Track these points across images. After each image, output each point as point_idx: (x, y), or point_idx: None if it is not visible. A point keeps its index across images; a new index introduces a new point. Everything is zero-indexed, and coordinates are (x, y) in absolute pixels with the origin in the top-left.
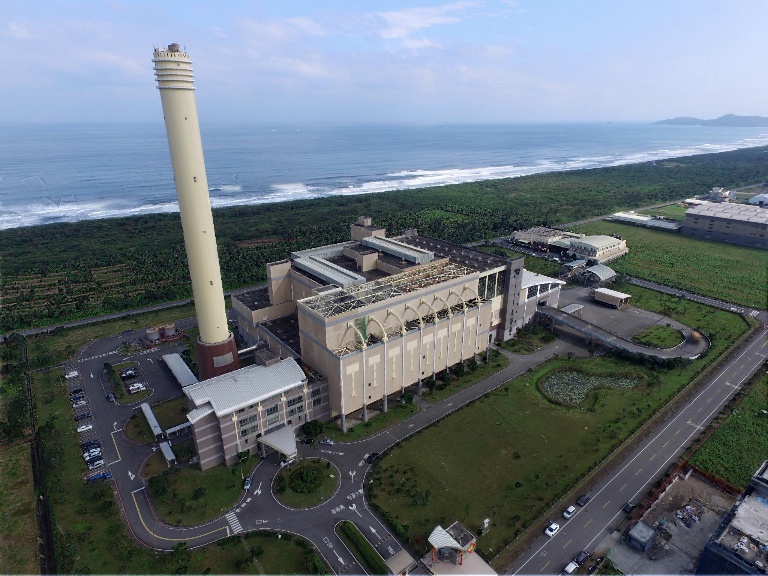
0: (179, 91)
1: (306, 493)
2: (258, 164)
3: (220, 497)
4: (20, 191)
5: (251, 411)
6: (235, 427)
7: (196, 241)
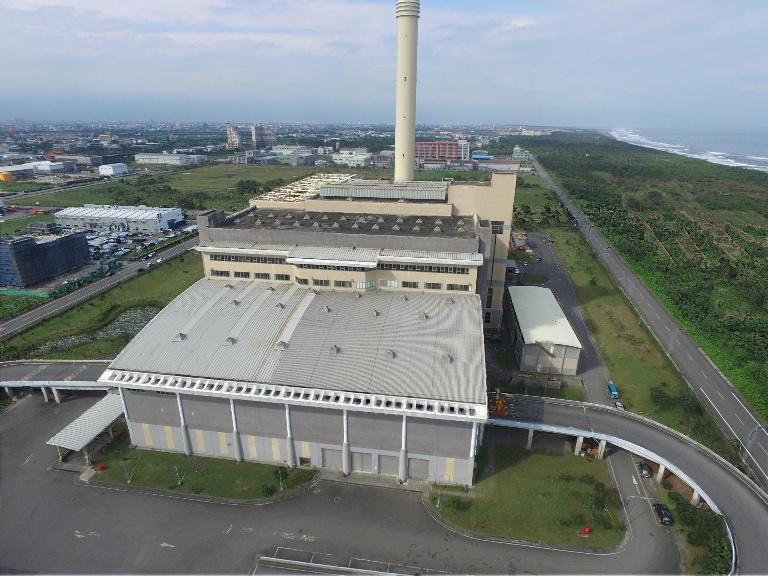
0: None
1: None
2: None
3: None
4: None
5: None
6: None
7: None
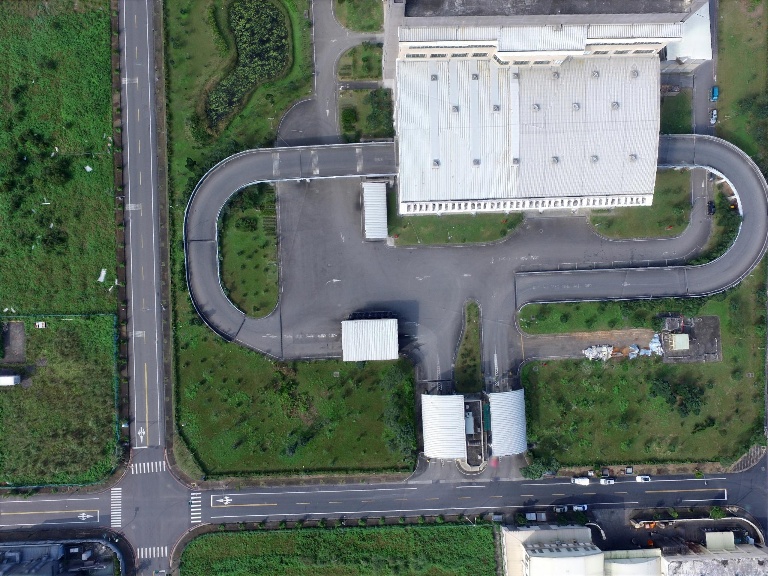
0: None
1: None
2: None
3: None
4: None
5: None
6: None
7: None
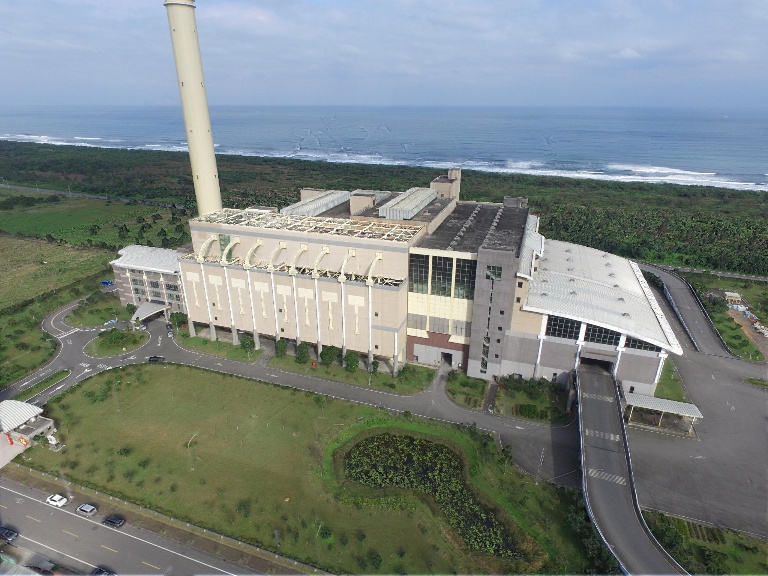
0: (169, 6)
1: (100, 345)
2: (561, 126)
3: (93, 320)
4: (385, 136)
5: (140, 276)
6: (130, 282)
7: (187, 138)
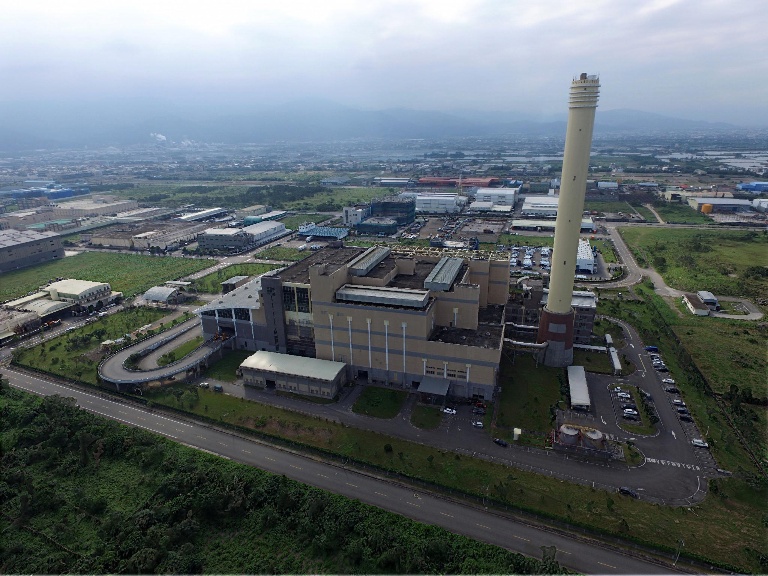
0: None
1: None
2: None
3: None
4: None
5: None
6: None
7: None
